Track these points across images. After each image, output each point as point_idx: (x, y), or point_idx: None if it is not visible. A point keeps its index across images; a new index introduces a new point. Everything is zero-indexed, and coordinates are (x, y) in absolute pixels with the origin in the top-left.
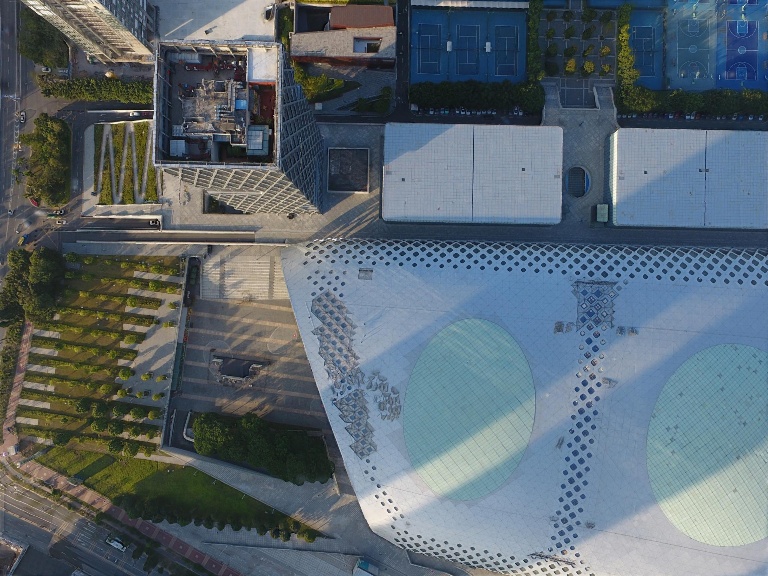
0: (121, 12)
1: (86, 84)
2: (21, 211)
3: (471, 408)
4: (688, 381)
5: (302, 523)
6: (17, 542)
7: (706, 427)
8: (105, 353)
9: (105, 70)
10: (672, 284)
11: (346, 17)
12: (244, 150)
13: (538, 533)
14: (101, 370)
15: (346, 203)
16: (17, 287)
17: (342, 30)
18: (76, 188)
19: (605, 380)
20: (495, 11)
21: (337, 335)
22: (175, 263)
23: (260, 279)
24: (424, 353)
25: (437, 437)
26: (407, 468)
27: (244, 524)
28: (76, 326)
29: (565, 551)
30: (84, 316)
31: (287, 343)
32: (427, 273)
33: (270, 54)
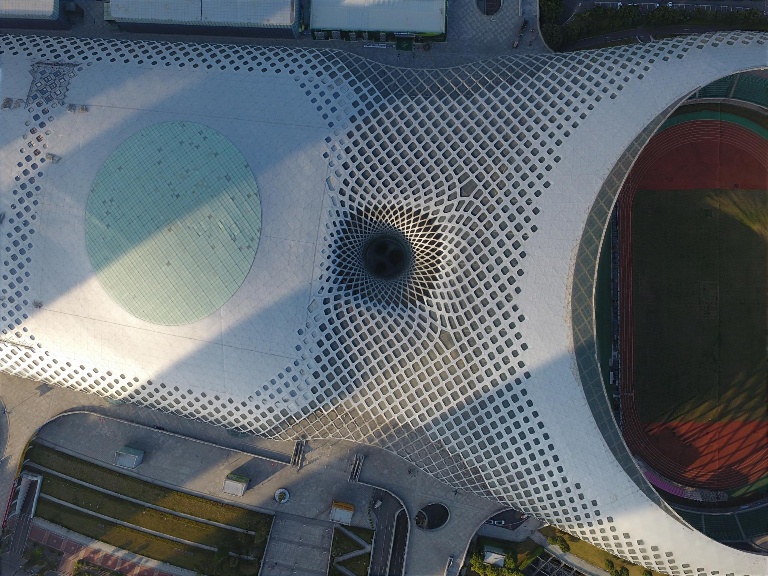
0: None
1: None
2: None
3: None
4: (128, 155)
5: None
6: None
7: (139, 199)
8: None
9: None
10: (137, 67)
11: None
12: None
13: None
14: None
15: None
16: None
17: None
18: None
19: (48, 155)
20: None
21: None
22: None
23: None
24: None
25: None
26: None
27: None
28: None
29: (20, 334)
30: None
31: None
32: None
33: None
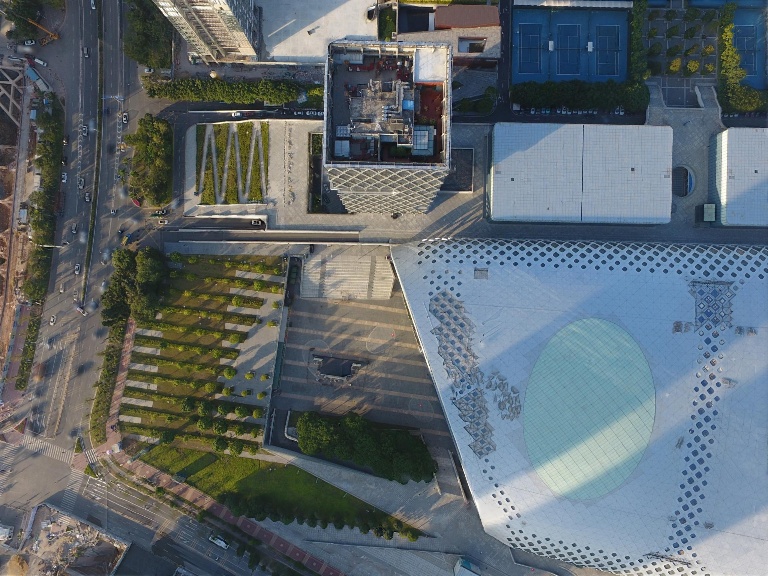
0: (239, 13)
1: (191, 85)
2: (124, 211)
3: (592, 408)
4: None
5: (403, 522)
6: (120, 539)
7: None
8: (207, 352)
9: (206, 71)
10: None
11: (452, 17)
12: (408, 150)
13: (655, 533)
14: (203, 369)
15: (450, 203)
16: (124, 286)
17: (447, 30)
18: (178, 188)
19: (725, 380)
20: (596, 10)
21: (456, 335)
22: (277, 263)
23: (360, 279)
24: (544, 353)
25: (557, 437)
26: (526, 467)
27: (347, 522)
28: (179, 325)
29: (682, 551)
30: (186, 315)
31: (386, 342)
32: (542, 273)
33: (436, 54)
